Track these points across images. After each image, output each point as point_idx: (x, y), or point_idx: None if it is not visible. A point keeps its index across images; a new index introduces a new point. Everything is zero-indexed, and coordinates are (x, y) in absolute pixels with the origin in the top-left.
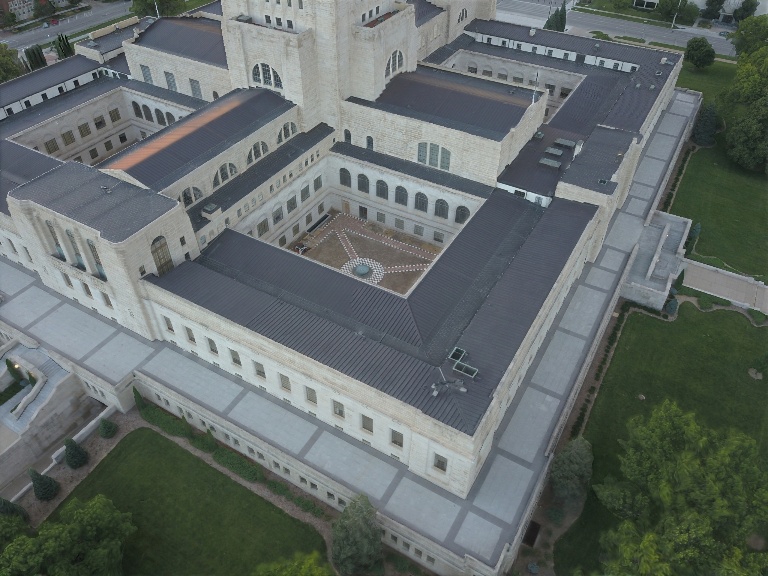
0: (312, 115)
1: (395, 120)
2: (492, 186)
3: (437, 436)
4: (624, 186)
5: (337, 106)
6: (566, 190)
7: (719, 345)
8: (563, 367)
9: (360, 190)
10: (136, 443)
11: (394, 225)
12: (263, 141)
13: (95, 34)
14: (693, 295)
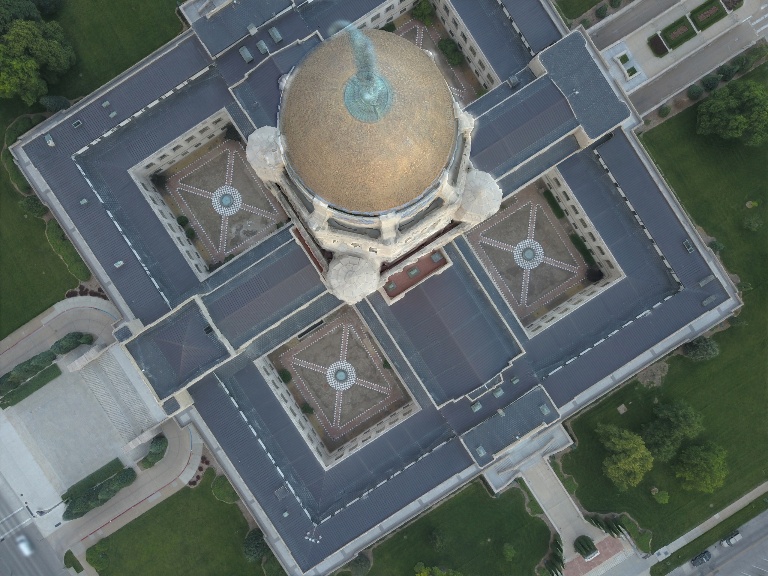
0: None
1: None
2: None
3: None
4: None
5: None
6: None
7: None
8: None
9: None
10: (573, 11)
11: None
12: None
13: None
14: None
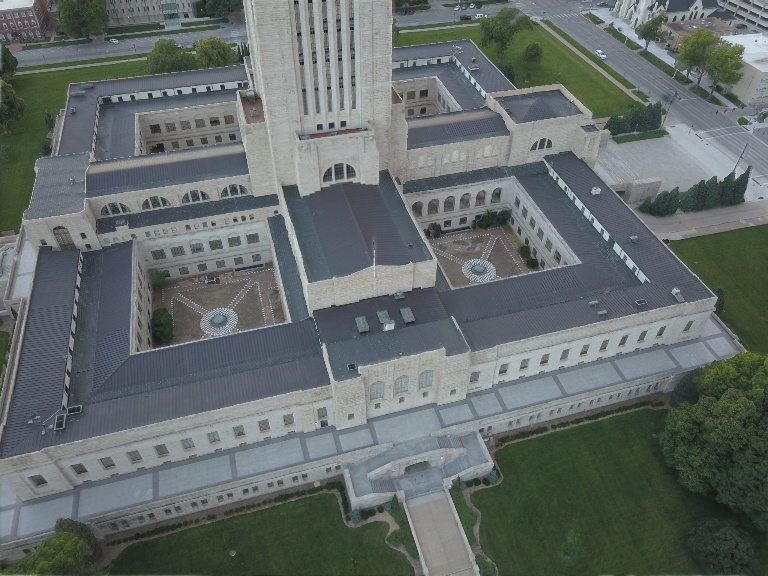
0: (263, 186)
1: None
2: (309, 315)
3: None
4: (438, 387)
5: None
6: None
7: None
8: (190, 481)
9: None
10: None
11: None
12: (203, 191)
13: None
14: (399, 523)
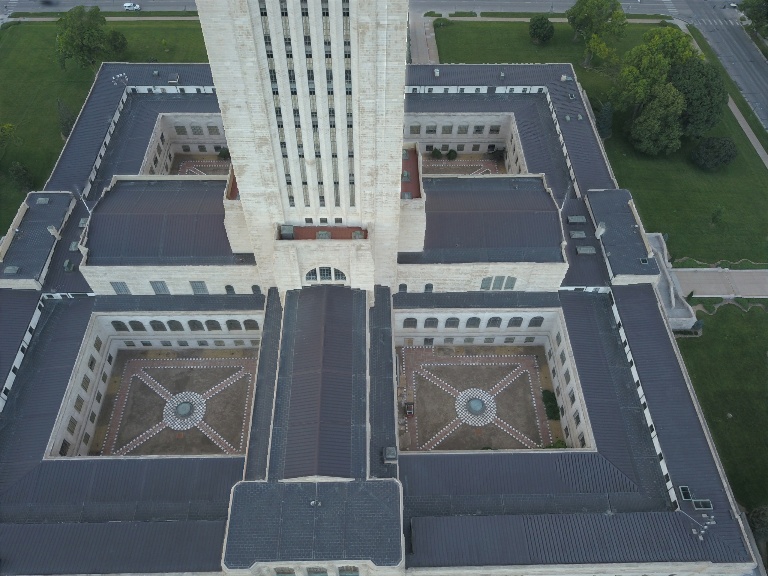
0: None
1: (460, 268)
2: (556, 291)
3: (723, 570)
4: None
5: (394, 271)
6: (623, 280)
7: (739, 341)
8: None
9: (426, 328)
10: None
11: (463, 343)
12: None
13: (1, 254)
14: (698, 303)
